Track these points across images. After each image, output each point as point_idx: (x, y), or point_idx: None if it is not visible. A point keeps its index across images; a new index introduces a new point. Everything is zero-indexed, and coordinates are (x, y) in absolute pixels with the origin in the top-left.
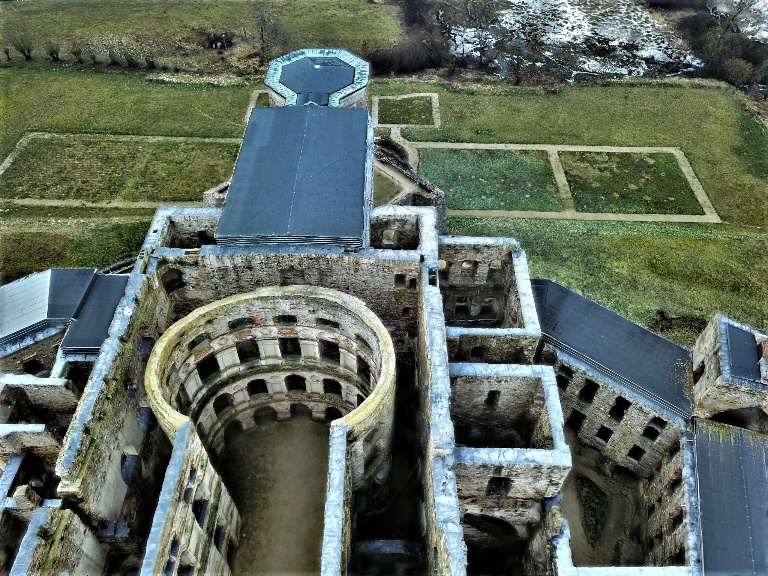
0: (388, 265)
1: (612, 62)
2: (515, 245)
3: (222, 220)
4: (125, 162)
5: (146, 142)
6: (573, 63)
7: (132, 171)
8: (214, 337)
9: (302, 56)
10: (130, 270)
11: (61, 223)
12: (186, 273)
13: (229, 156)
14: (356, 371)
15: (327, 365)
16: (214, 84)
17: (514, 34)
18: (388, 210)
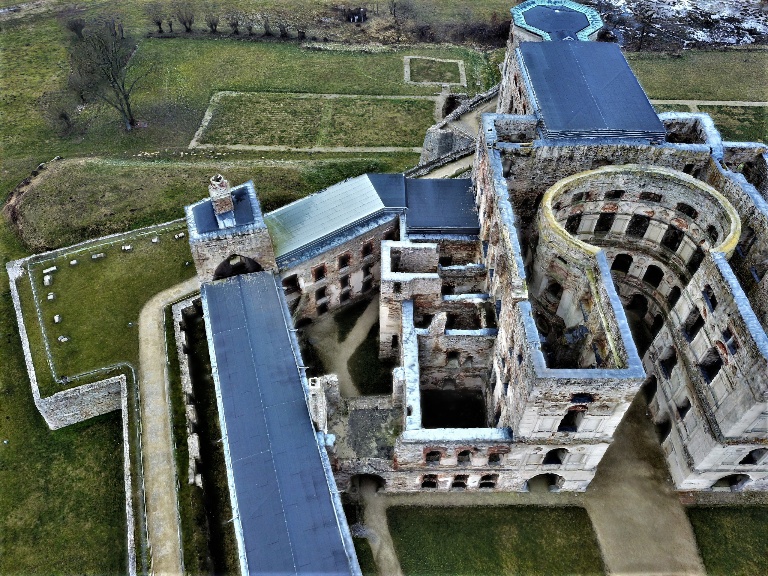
0: (684, 155)
1: (718, 33)
2: (766, 148)
3: (547, 120)
4: (313, 115)
5: (325, 99)
6: (683, 34)
7: (321, 122)
8: (561, 208)
9: (534, 5)
10: None
11: (281, 162)
12: (516, 164)
13: (404, 110)
14: (660, 241)
15: (628, 240)
16: (367, 51)
17: (621, 9)
18: (671, 115)
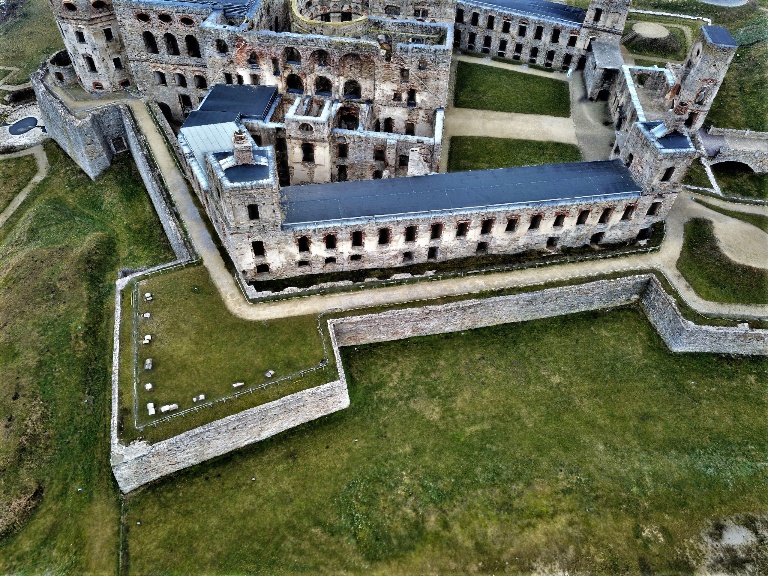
0: None
1: None
2: None
3: (234, 2)
4: None
5: None
6: None
7: None
8: None
9: None
10: (152, 158)
11: None
12: None
13: None
14: None
15: None
16: None
17: None
18: None
